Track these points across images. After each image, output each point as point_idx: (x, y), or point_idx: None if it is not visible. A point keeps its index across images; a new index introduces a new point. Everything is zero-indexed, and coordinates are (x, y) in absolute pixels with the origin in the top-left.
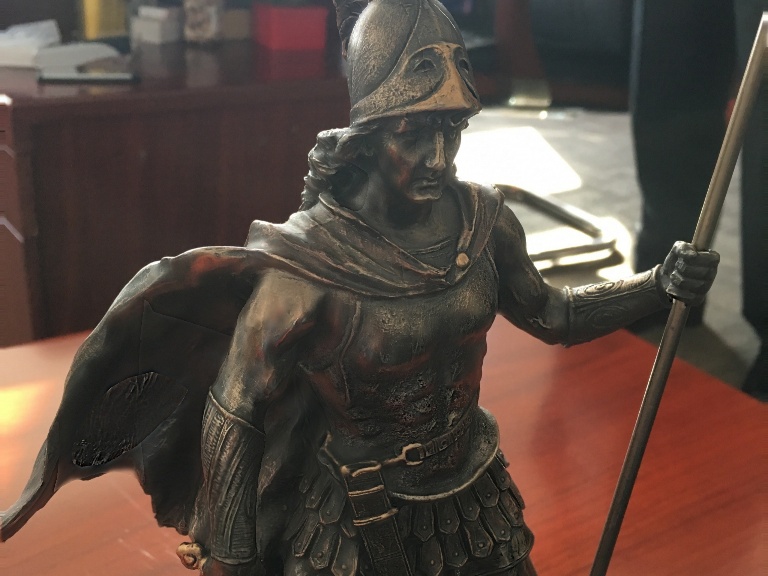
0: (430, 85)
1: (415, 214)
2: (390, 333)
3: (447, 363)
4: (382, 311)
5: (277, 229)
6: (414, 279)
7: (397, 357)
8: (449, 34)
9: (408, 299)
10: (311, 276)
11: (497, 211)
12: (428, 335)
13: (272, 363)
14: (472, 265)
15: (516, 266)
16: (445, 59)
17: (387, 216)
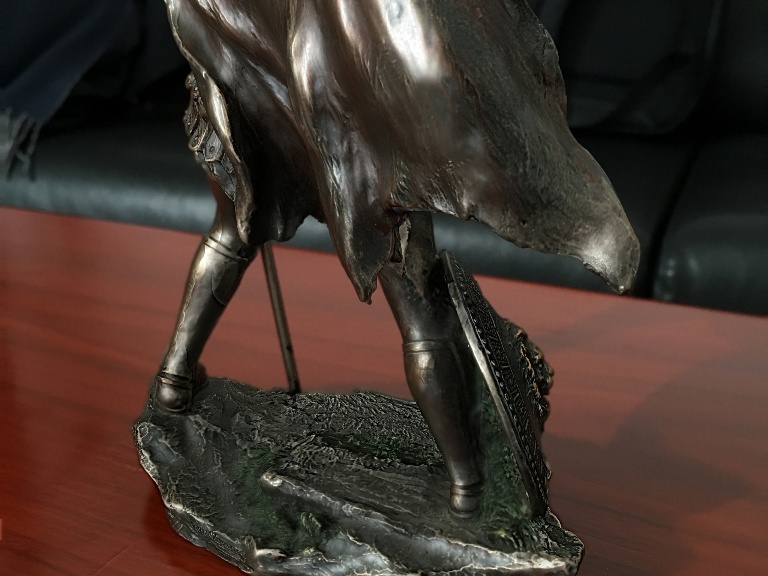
0: None
1: None
2: None
3: None
4: None
5: None
6: None
7: None
8: None
9: None
10: None
11: None
12: None
13: None
14: None
15: None
16: None
17: None
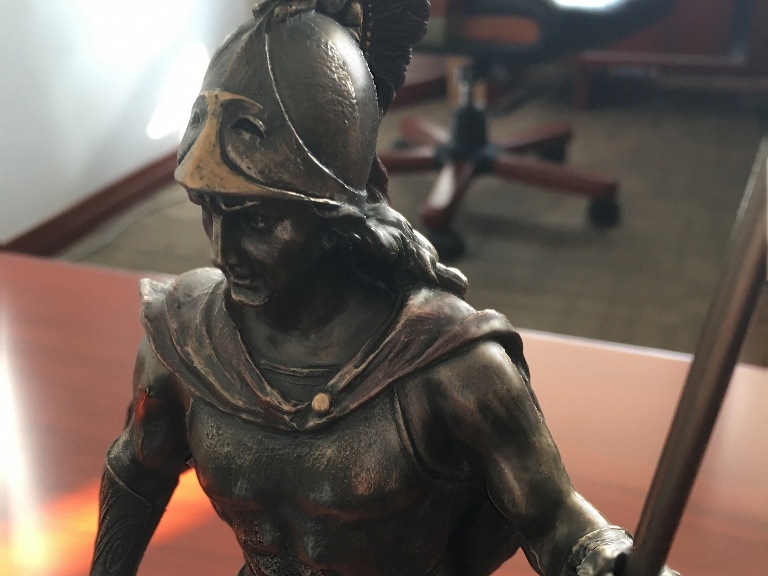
0: (184, 146)
1: (294, 318)
2: (210, 452)
3: (298, 530)
4: (210, 421)
5: (174, 283)
6: (253, 400)
7: (215, 486)
8: (241, 79)
9: (243, 421)
10: (152, 346)
11: (424, 356)
12: (259, 479)
13: (143, 426)
14: (340, 416)
15: (482, 452)
16: (208, 113)
17: (263, 308)
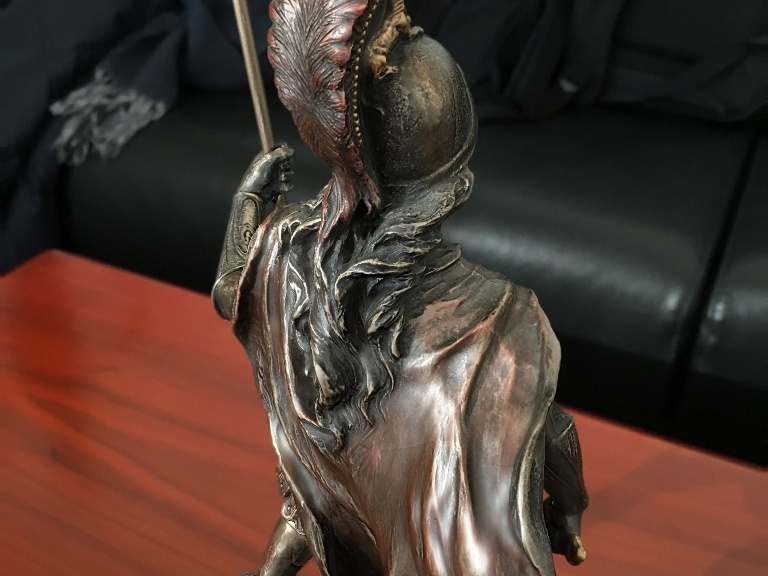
0: None
1: None
2: None
3: None
4: None
5: None
6: None
7: None
8: None
9: None
10: None
11: None
12: None
13: None
14: None
15: None
16: None
17: None
